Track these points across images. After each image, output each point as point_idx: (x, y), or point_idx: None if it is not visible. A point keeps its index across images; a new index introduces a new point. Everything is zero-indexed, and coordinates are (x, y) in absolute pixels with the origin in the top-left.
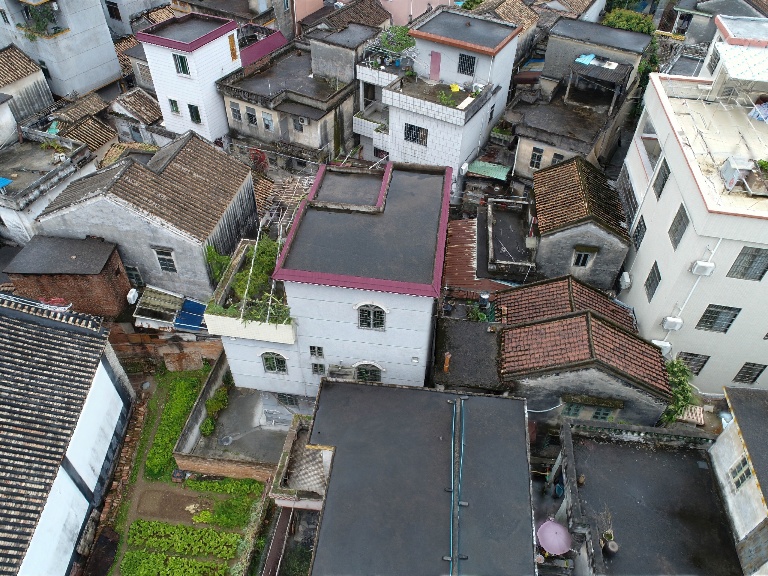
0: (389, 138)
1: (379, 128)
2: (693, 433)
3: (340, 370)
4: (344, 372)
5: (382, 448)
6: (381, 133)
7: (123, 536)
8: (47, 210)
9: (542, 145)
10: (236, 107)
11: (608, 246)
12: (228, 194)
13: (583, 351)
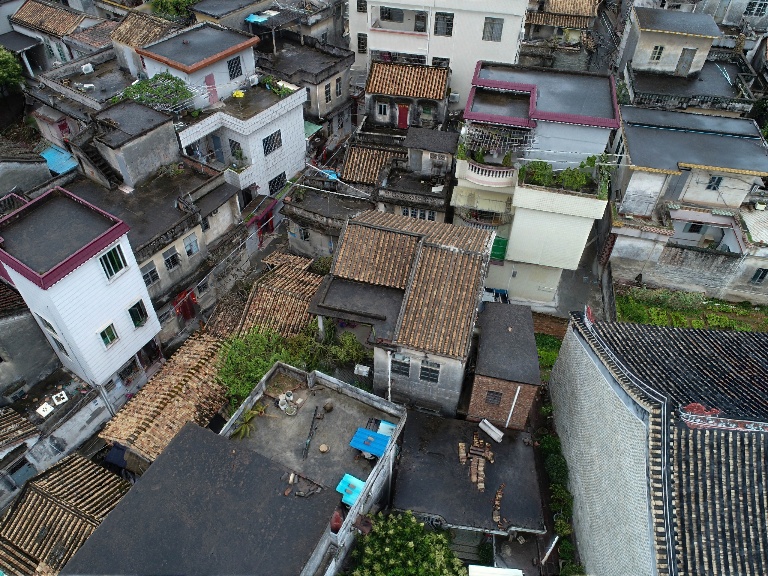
0: (253, 168)
1: (234, 170)
2: None
3: None
4: None
5: (670, 149)
6: (245, 170)
7: None
8: None
9: (329, 80)
10: (151, 268)
11: None
12: None
13: None
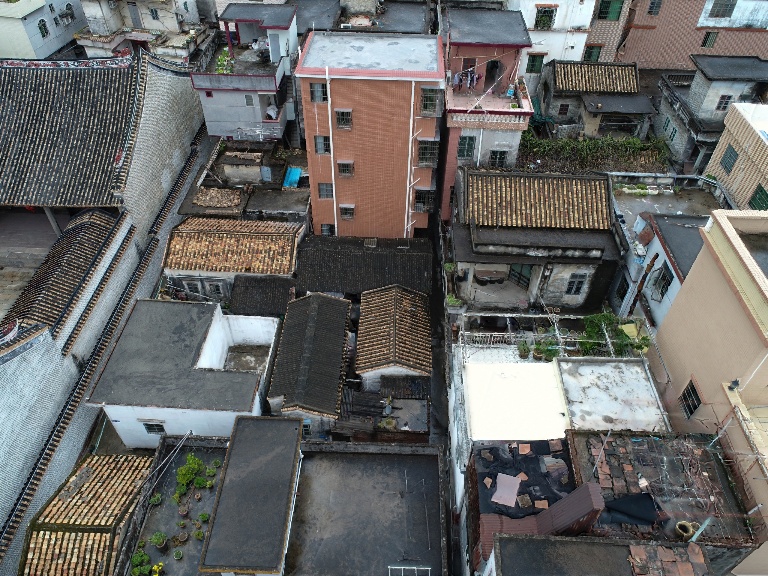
0: None
1: None
2: None
3: (64, 13)
4: (65, 12)
5: None
6: None
7: None
8: None
9: None
10: None
11: None
12: None
13: None
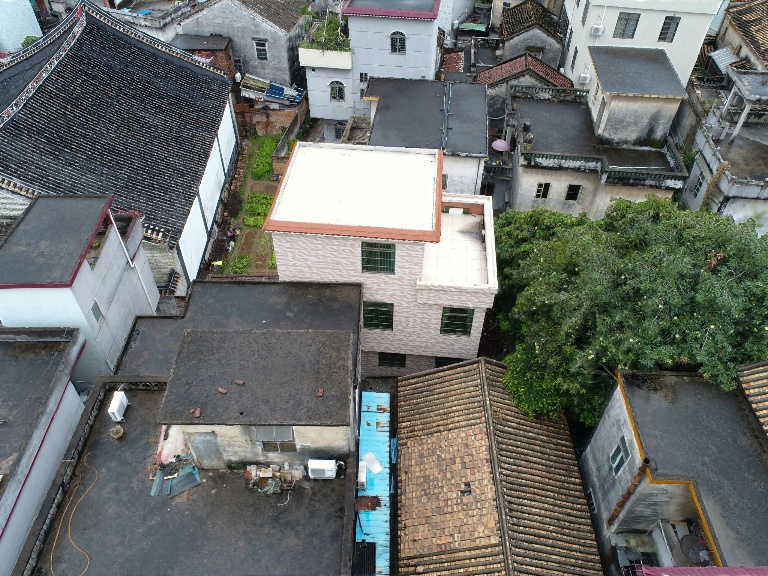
0: None
1: None
2: (578, 89)
3: None
4: None
5: (406, 98)
6: None
7: (244, 200)
8: (187, 16)
9: None
10: None
11: (549, 47)
12: (299, 13)
13: (522, 68)
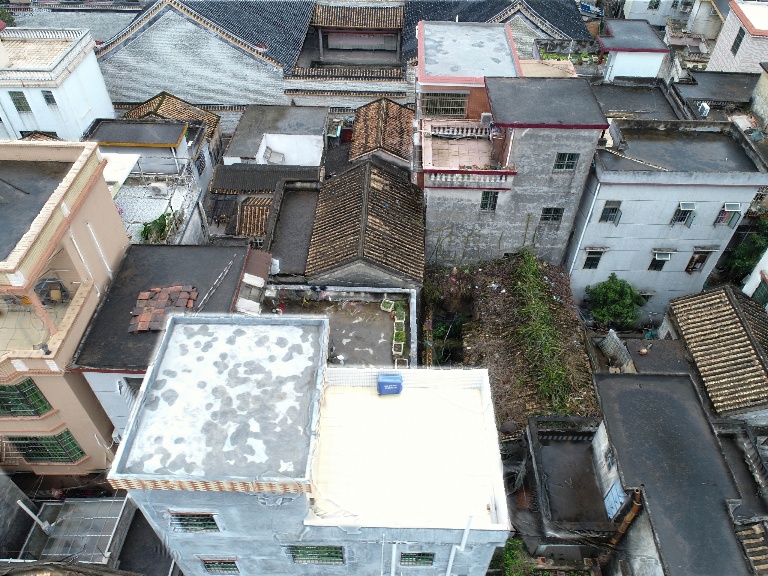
0: None
1: None
2: None
3: (688, 1)
4: (690, 2)
5: (729, 0)
6: None
7: None
8: None
9: None
10: None
11: None
12: None
13: None
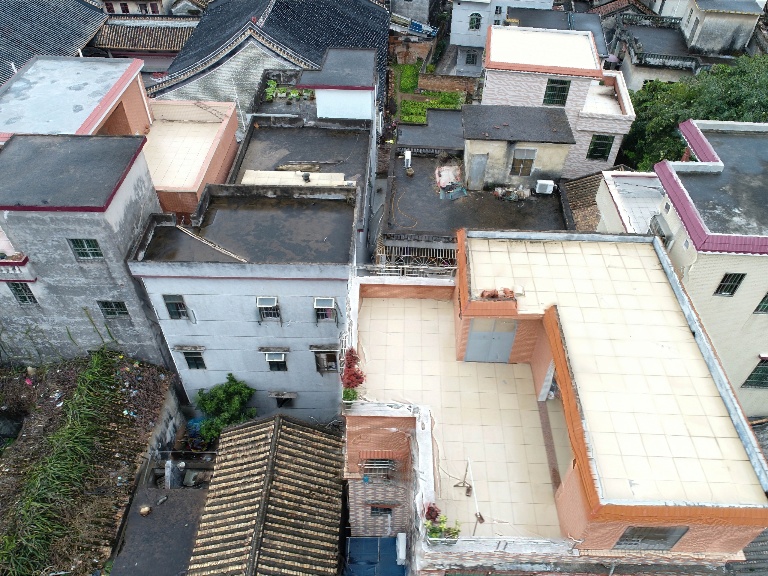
0: None
1: None
2: (673, 17)
3: None
4: None
5: (539, 21)
6: None
7: (398, 105)
8: None
9: None
10: None
11: None
12: None
13: None
